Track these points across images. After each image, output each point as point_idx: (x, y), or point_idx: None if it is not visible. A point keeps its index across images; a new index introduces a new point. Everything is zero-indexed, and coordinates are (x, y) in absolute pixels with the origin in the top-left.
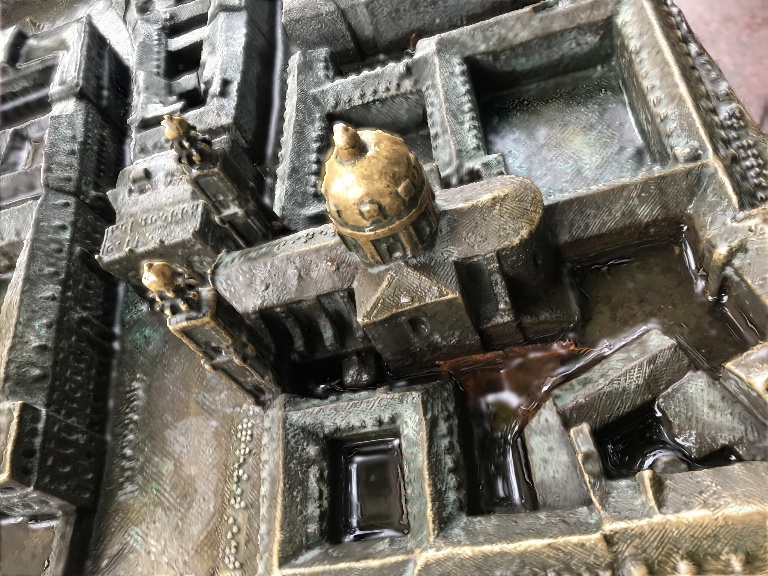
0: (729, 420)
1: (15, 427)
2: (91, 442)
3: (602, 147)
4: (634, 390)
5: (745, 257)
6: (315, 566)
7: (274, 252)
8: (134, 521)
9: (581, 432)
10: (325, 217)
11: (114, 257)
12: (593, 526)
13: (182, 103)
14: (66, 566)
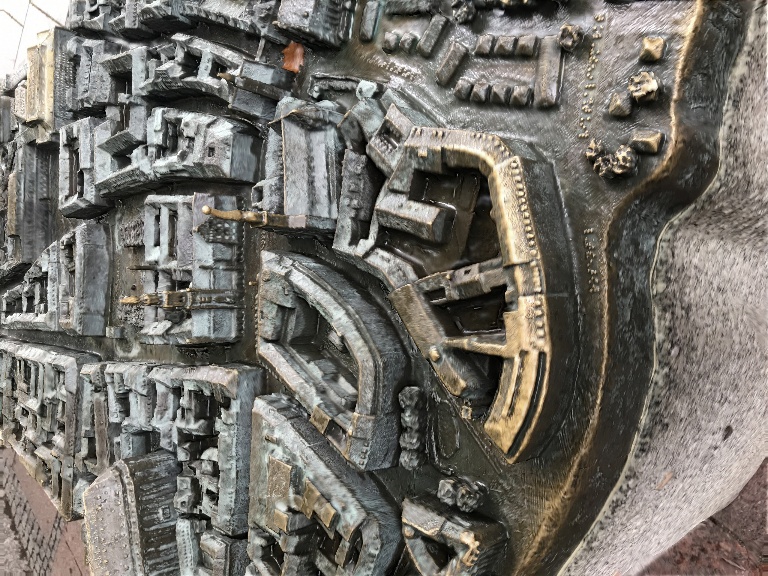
0: None
1: None
2: None
3: None
4: None
5: None
6: None
7: None
8: None
9: None
10: None
11: None
12: None
13: (5, 311)
14: None
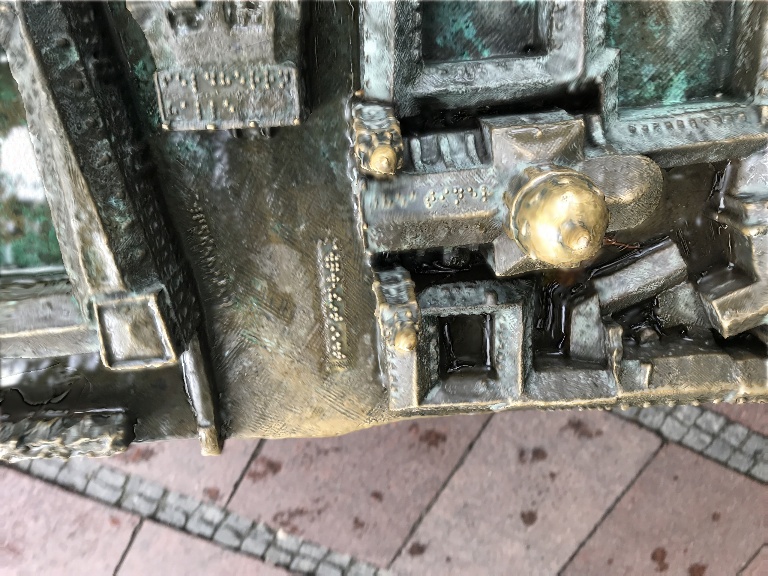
0: (692, 314)
1: (161, 320)
2: (183, 273)
3: (696, 12)
4: (649, 293)
5: (762, 236)
6: (443, 404)
7: (426, 208)
8: (242, 325)
9: (617, 334)
10: (433, 99)
11: (188, 128)
12: (611, 390)
13: None
14: (206, 368)
